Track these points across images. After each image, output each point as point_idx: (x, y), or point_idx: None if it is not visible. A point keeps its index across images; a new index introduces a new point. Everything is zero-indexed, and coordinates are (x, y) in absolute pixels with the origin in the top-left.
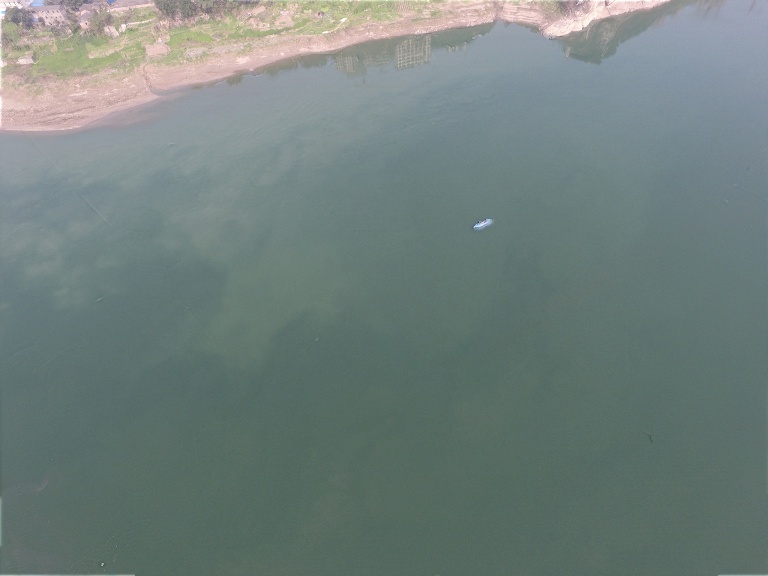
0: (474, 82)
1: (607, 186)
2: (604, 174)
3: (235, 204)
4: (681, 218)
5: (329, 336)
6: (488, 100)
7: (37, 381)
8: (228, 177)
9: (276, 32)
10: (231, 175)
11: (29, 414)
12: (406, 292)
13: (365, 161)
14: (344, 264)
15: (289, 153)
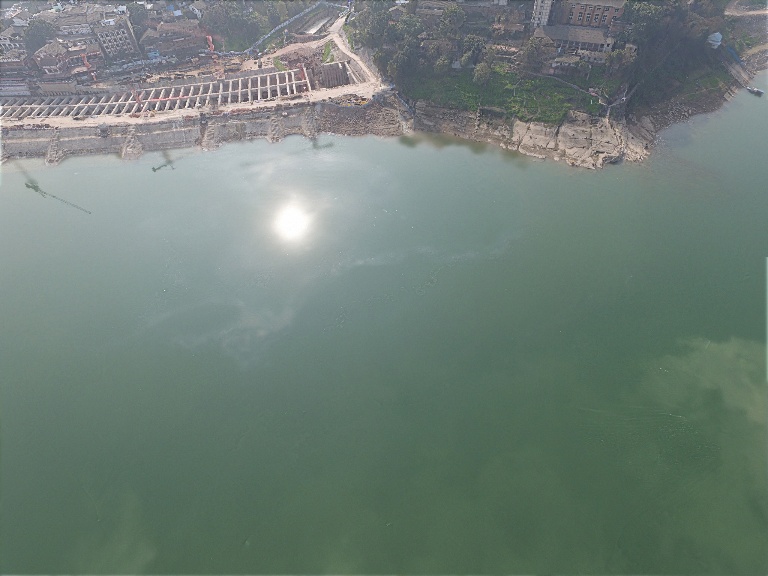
0: None
1: None
2: None
3: None
4: None
5: None
6: None
7: (262, 402)
8: None
9: None
10: None
11: (260, 374)
12: None
13: None
14: None
15: None
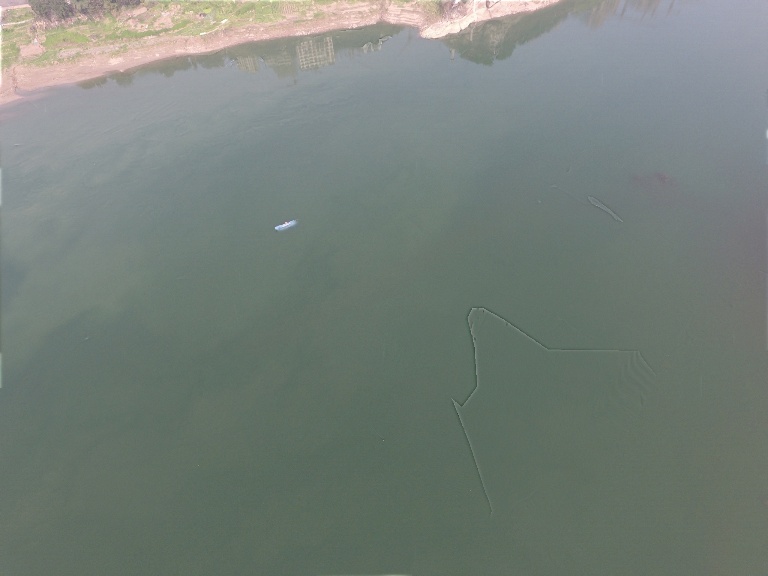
0: (337, 84)
1: (416, 187)
2: (418, 175)
3: (59, 204)
4: (484, 218)
5: (100, 335)
6: (345, 101)
7: None
8: (62, 178)
9: (154, 33)
10: (66, 176)
11: None
12: (190, 291)
13: (200, 162)
14: (141, 264)
15: (130, 154)
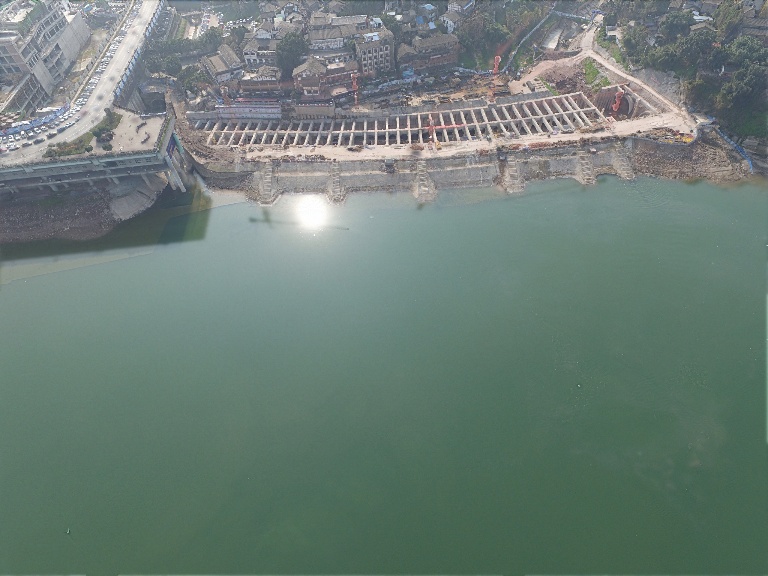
0: None
1: None
2: None
3: None
4: None
5: None
6: None
7: None
8: None
9: None
10: None
11: None
12: None
13: None
14: None
15: None
